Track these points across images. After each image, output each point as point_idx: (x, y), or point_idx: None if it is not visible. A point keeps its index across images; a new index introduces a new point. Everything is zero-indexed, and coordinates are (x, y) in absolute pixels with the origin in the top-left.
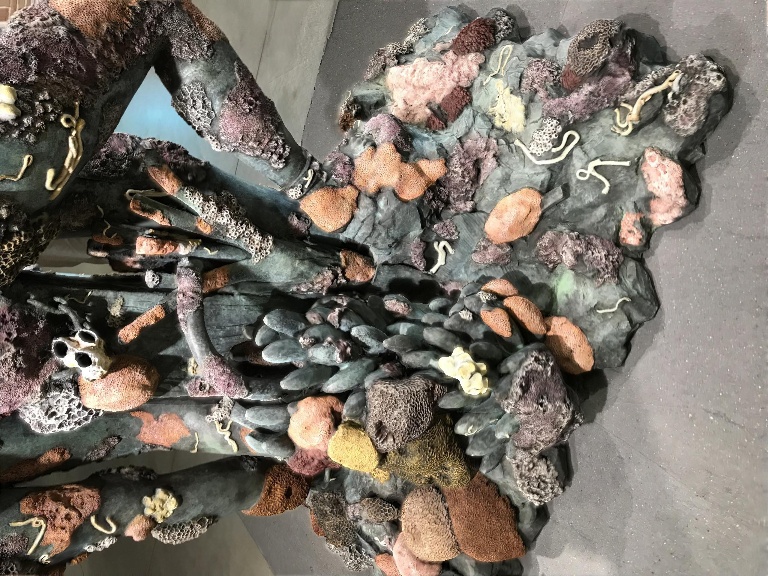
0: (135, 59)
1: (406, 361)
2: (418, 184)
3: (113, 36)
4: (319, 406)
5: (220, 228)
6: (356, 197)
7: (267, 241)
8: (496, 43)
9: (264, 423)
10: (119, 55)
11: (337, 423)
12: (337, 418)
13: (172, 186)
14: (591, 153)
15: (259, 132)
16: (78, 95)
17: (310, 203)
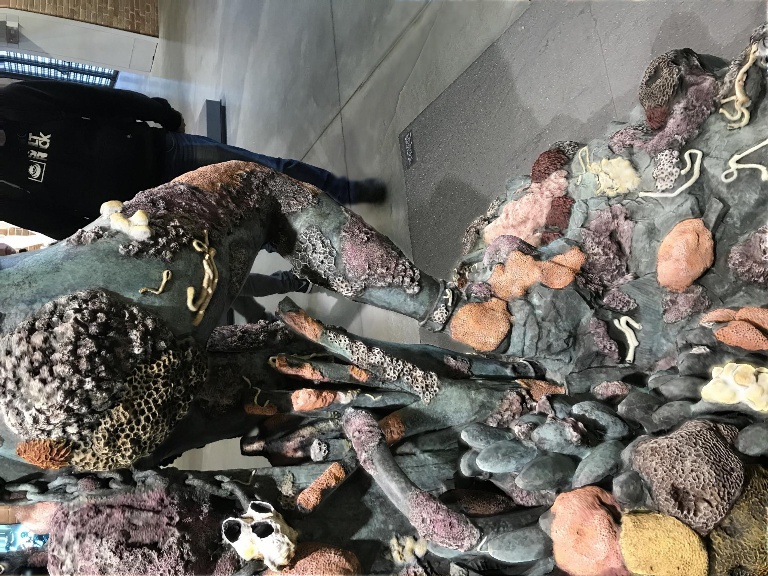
0: (251, 212)
1: (660, 418)
2: (563, 272)
3: (227, 191)
4: (580, 496)
5: (376, 371)
6: (506, 307)
7: (431, 377)
8: (570, 159)
9: (518, 555)
10: (236, 206)
11: (617, 517)
12: (613, 513)
13: (314, 330)
14: (723, 155)
15: (383, 258)
16: (205, 227)
17: (460, 322)
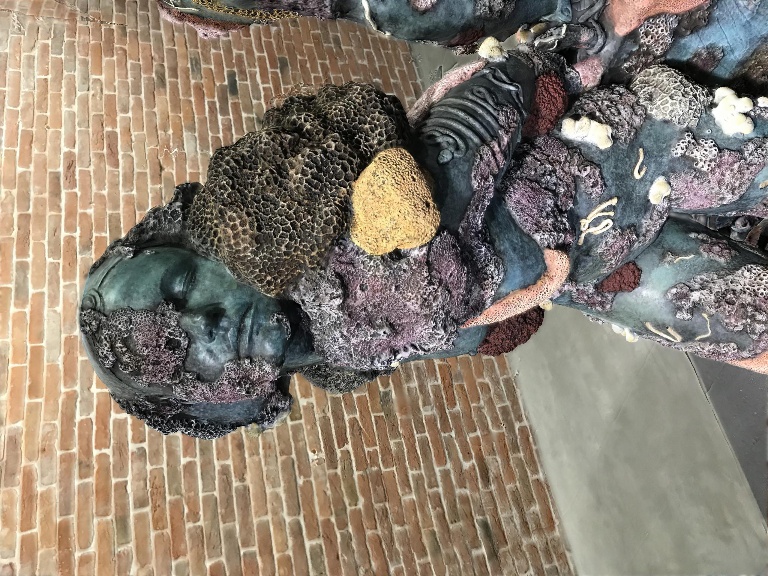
0: None
1: (731, 236)
2: None
3: None
4: None
5: None
6: None
7: None
8: None
9: None
10: None
11: None
12: None
13: None
14: None
15: None
16: None
17: None
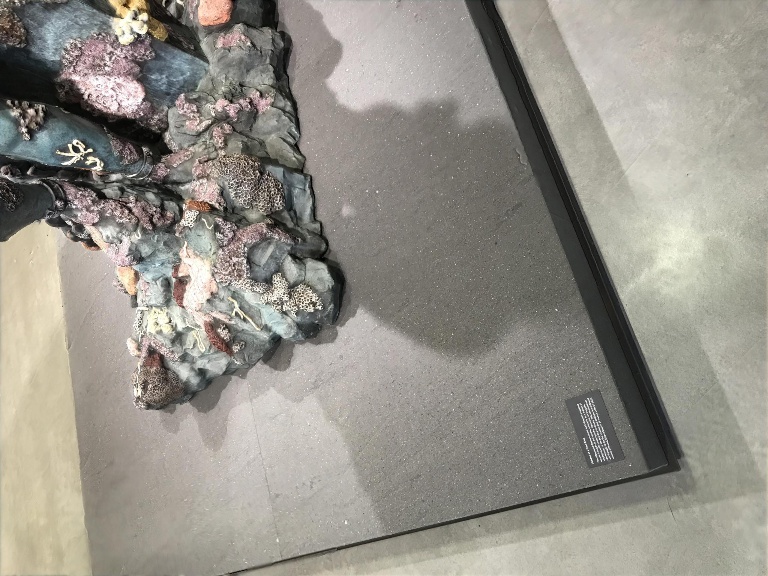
0: None
1: None
2: None
3: None
4: None
5: None
6: None
7: None
8: None
9: None
10: None
11: None
12: None
13: None
14: None
15: None
16: None
17: None
